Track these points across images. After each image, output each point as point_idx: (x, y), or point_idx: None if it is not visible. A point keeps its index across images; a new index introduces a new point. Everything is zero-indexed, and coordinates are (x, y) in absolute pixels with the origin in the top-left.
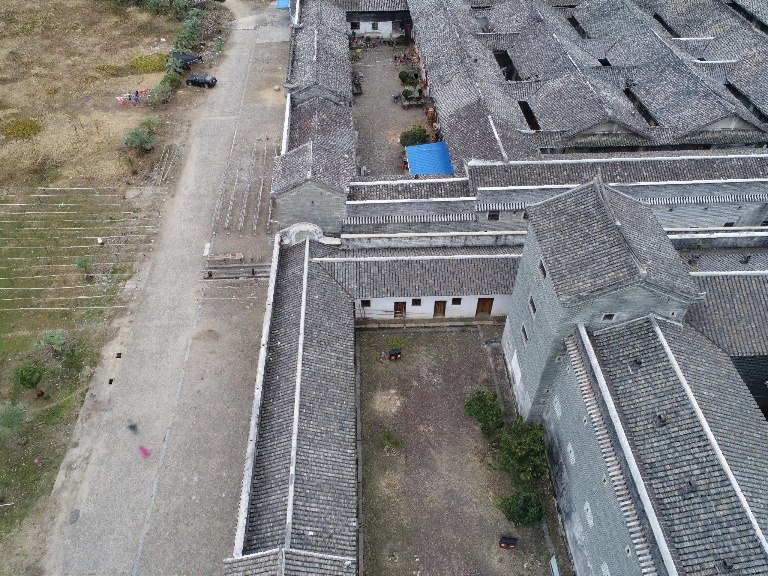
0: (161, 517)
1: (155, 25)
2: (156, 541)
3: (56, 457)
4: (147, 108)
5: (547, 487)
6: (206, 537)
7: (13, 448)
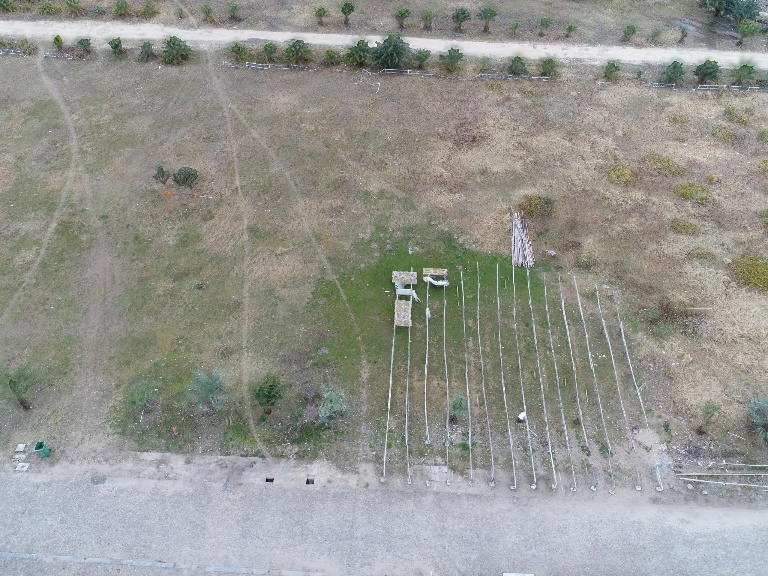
0: (53, 574)
1: None
2: (26, 572)
3: (180, 446)
4: None
5: None
6: None
7: None
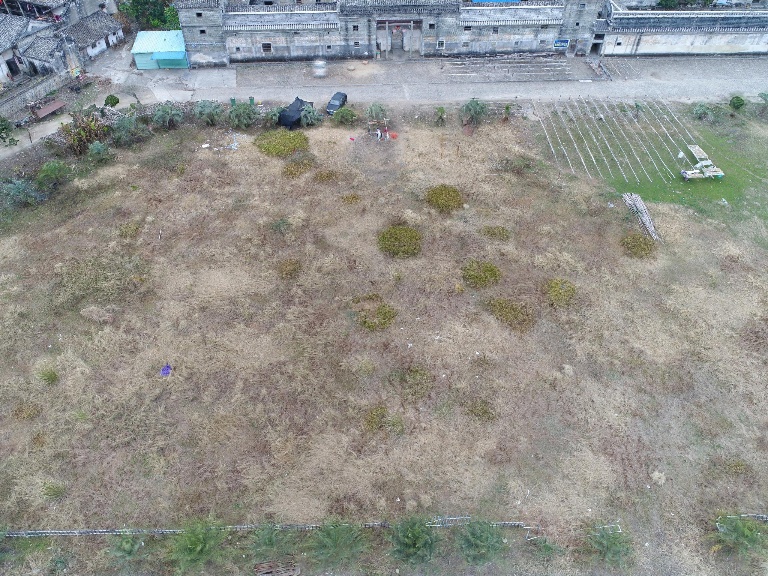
0: (762, 76)
1: (151, 158)
2: None
3: (760, 105)
4: (388, 132)
5: (682, 7)
6: (760, 66)
7: (766, 119)
